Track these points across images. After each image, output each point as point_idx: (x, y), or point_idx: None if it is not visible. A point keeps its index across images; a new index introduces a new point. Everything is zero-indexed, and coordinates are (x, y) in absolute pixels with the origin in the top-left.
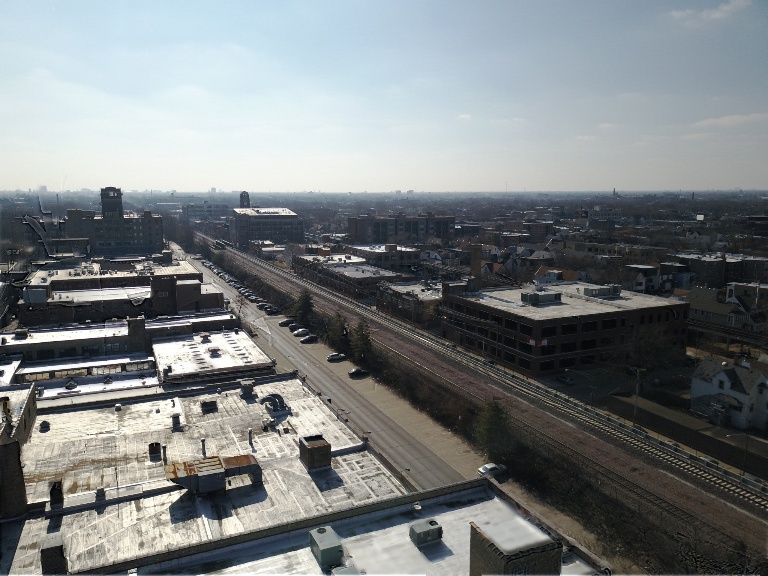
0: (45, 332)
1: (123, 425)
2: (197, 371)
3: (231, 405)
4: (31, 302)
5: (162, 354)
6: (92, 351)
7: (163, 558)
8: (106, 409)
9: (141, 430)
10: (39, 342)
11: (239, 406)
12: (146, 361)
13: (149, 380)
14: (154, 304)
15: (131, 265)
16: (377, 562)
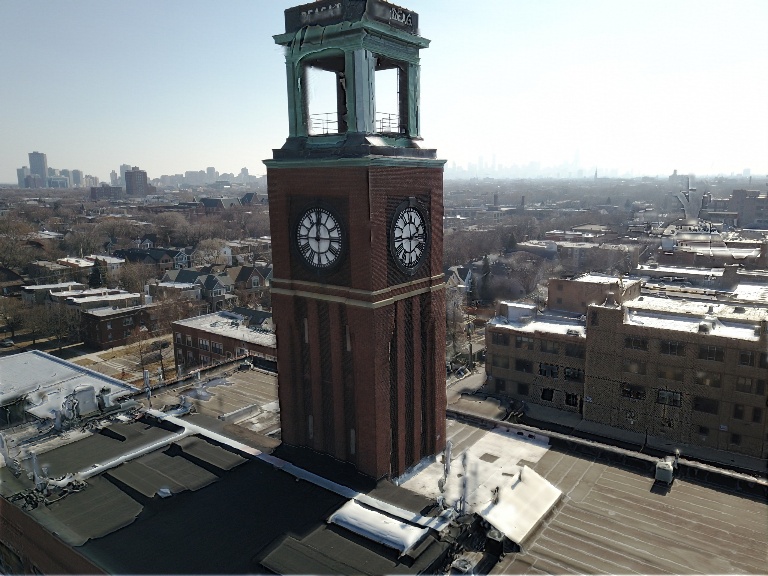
0: (669, 268)
1: (681, 306)
2: (755, 300)
3: (755, 313)
4: (663, 246)
5: (739, 290)
6: (694, 283)
7: (647, 311)
8: (677, 300)
9: (688, 309)
10: (662, 271)
11: (760, 314)
12: (727, 293)
13: (709, 291)
14: (760, 262)
15: (761, 235)
16: (729, 331)
